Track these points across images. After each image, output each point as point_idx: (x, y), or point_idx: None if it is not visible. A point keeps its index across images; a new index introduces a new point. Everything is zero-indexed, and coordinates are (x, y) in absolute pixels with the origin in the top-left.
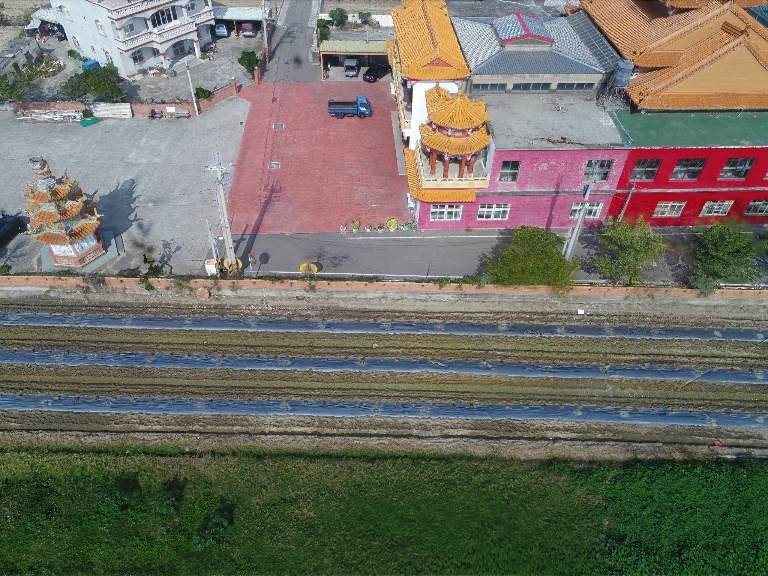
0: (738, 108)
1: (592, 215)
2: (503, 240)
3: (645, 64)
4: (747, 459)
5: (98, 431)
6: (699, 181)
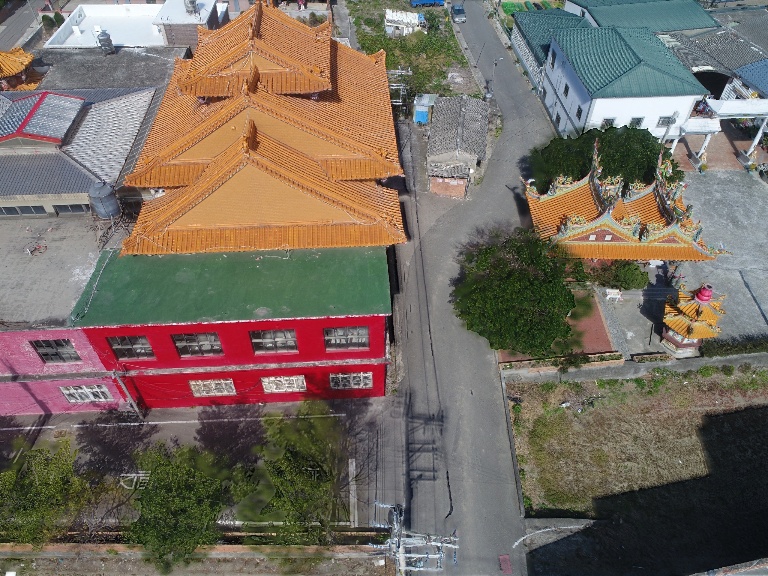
0: (279, 249)
1: (103, 397)
2: None
3: (146, 183)
4: None
5: None
6: (228, 357)
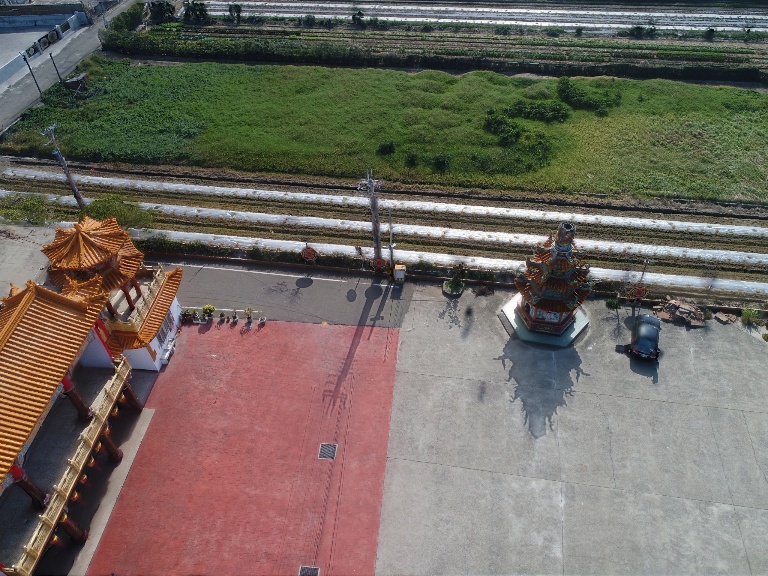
0: None
1: None
2: None
3: None
4: (88, 157)
5: (466, 198)
6: None
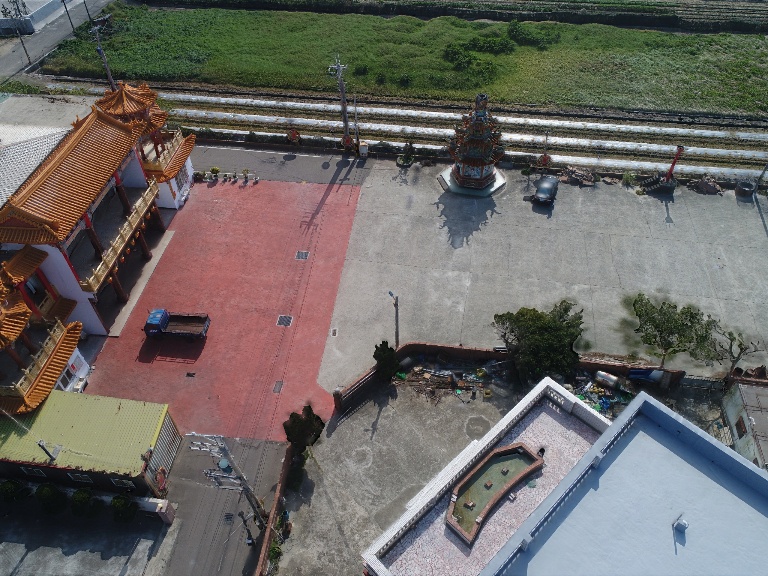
0: None
1: None
2: None
3: None
4: (116, 75)
5: (423, 106)
6: None
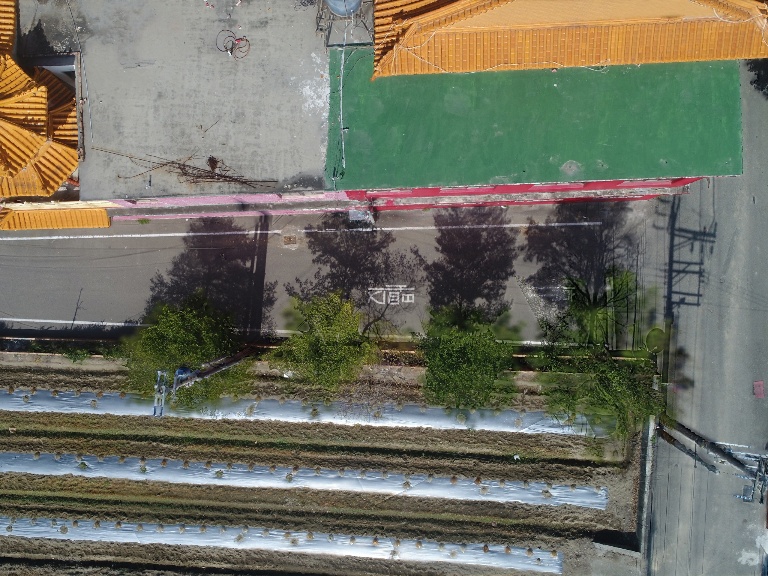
0: (595, 65)
1: None
2: (193, 244)
3: None
4: None
5: None
6: (496, 190)
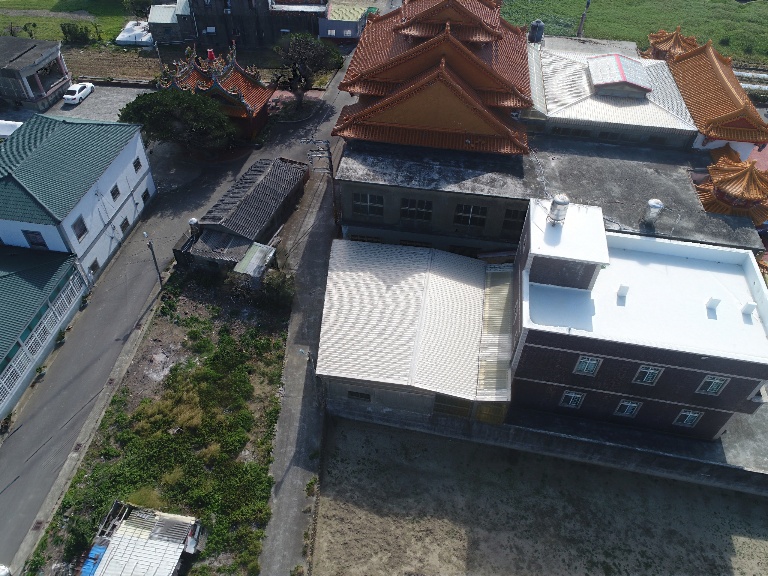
0: None
1: None
2: None
3: None
4: None
5: None
6: None
